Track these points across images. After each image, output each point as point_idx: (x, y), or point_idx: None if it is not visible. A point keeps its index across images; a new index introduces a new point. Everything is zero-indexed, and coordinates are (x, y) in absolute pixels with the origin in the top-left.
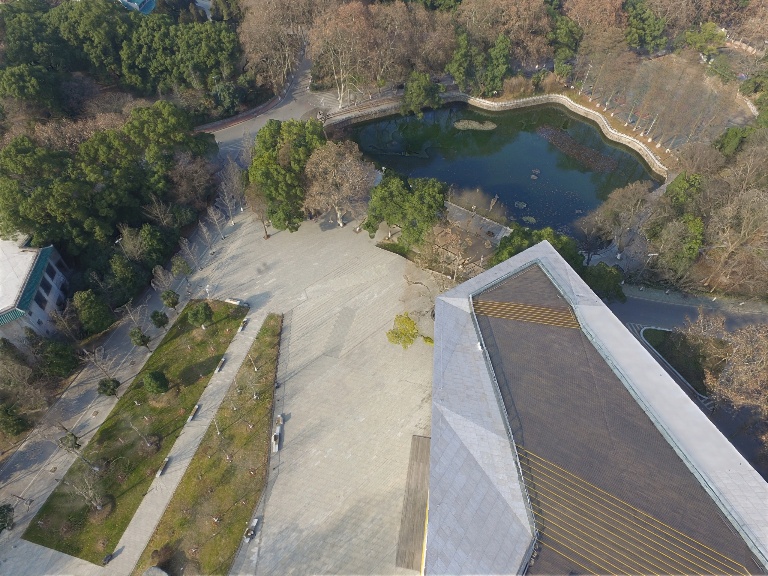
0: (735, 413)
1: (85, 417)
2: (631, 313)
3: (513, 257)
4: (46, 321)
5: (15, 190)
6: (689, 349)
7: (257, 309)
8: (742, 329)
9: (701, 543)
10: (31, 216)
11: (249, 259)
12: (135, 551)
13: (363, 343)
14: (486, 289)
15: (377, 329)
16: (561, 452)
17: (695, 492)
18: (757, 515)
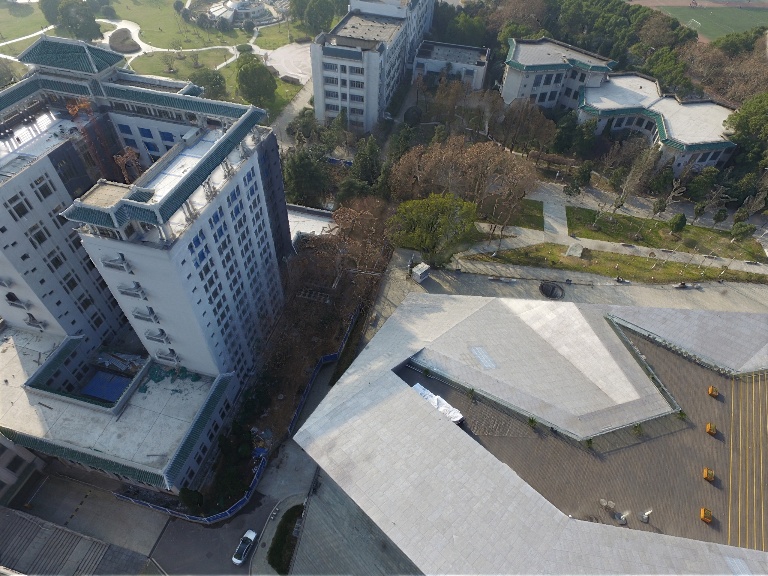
0: None
1: (633, 209)
2: None
3: None
4: (681, 168)
5: (765, 108)
6: None
7: None
8: None
9: None
10: (752, 123)
11: None
12: None
13: None
14: None
15: None
16: None
17: None
18: None
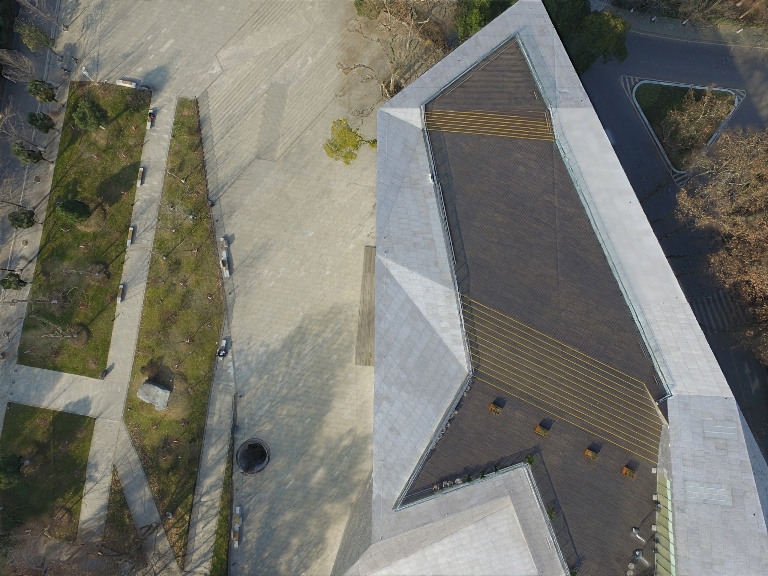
0: (696, 228)
1: (16, 248)
2: (630, 60)
3: (485, 28)
4: None
5: None
6: (677, 142)
7: (161, 93)
8: (746, 132)
9: (614, 368)
10: None
11: (126, 6)
12: (125, 366)
13: (301, 138)
14: (444, 90)
15: (316, 116)
16: (505, 298)
17: (624, 324)
18: (673, 342)
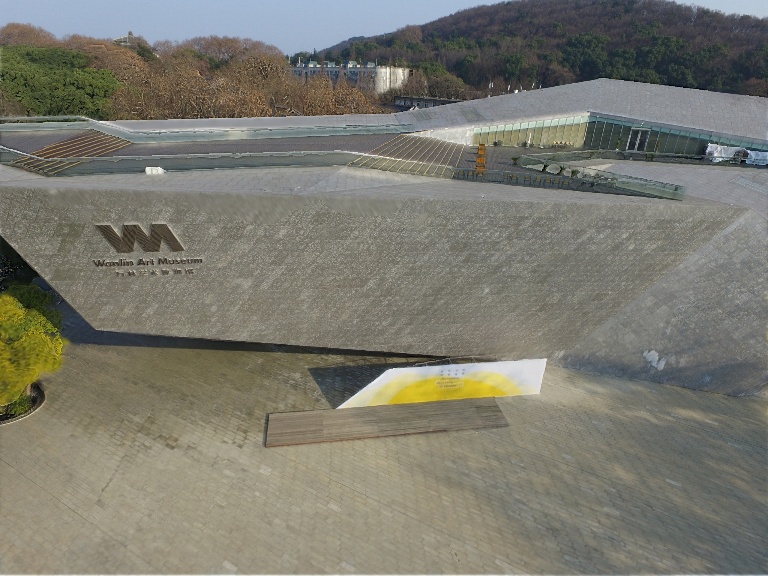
0: None
1: None
2: None
3: None
4: None
5: None
6: None
7: None
8: None
9: None
10: None
11: None
12: None
13: None
14: None
15: None
16: None
17: None
18: None
